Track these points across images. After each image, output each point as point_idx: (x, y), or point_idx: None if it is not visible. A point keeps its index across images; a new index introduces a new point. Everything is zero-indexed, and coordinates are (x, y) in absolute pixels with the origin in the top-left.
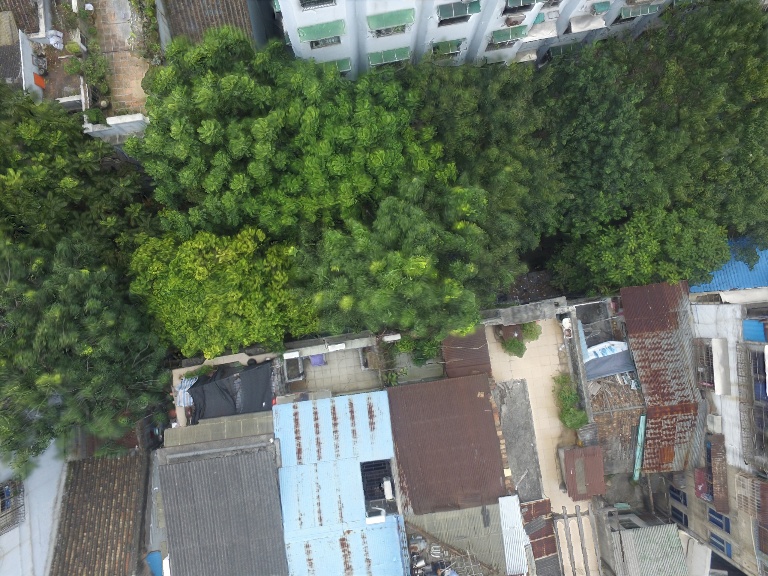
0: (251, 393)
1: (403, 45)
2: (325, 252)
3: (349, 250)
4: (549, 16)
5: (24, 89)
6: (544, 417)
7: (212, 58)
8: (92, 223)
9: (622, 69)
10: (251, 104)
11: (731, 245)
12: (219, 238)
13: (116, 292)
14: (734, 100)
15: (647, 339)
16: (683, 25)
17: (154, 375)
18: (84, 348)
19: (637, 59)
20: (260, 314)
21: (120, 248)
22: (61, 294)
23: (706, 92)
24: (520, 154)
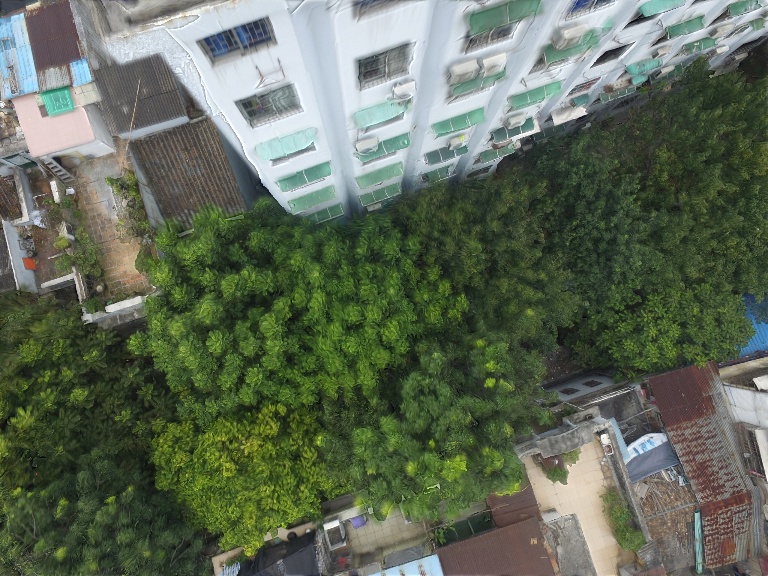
0: None
1: (392, 182)
2: (353, 431)
3: (382, 447)
4: None
5: (16, 280)
6: (598, 537)
7: (208, 256)
8: (106, 418)
9: (613, 162)
10: (254, 293)
11: (749, 305)
12: (240, 422)
13: (141, 481)
14: (730, 175)
15: (686, 430)
16: (666, 108)
17: (194, 572)
18: (121, 573)
19: (625, 144)
20: (295, 500)
21: (138, 436)
22: (91, 533)
23: (702, 175)
24: (529, 277)
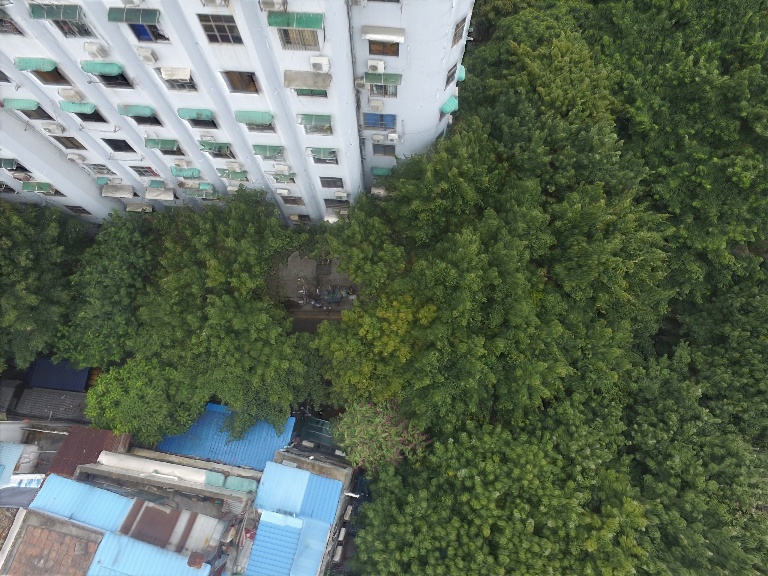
0: None
1: None
2: None
3: None
4: (113, 181)
5: None
6: None
7: None
8: None
9: None
10: None
11: None
12: None
13: None
14: None
15: None
16: (202, 213)
17: None
18: None
19: None
20: None
21: None
22: None
23: None
24: None
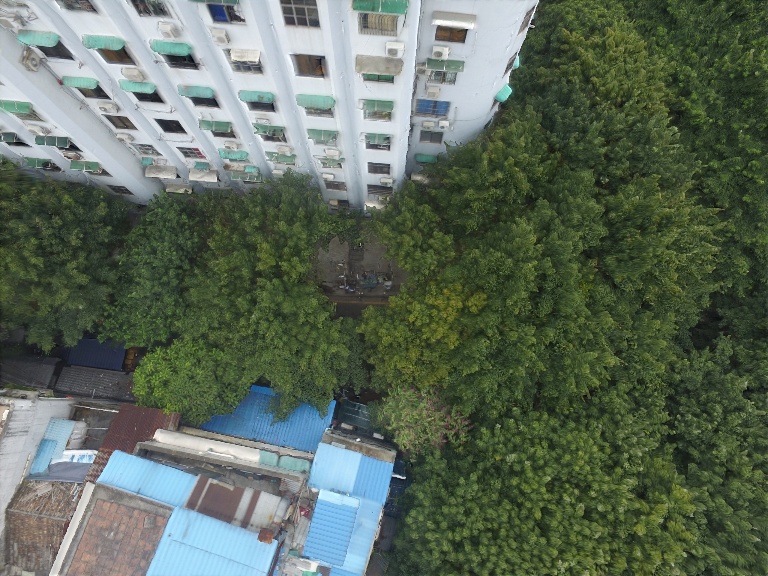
0: None
1: None
2: None
3: None
4: (158, 161)
5: None
6: None
7: None
8: None
9: None
10: None
11: None
12: None
13: None
14: None
15: None
16: (249, 196)
17: None
18: None
19: None
20: None
21: None
22: None
23: None
24: (27, 258)
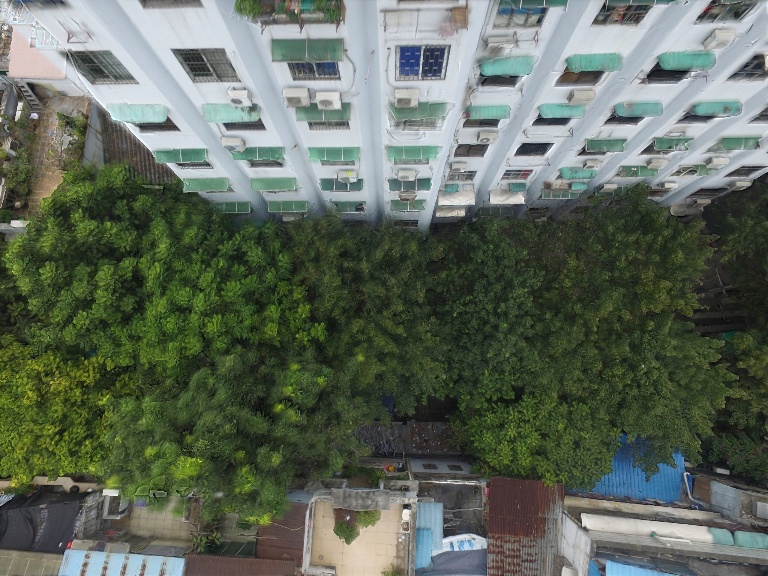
0: (54, 528)
1: (302, 199)
2: None
3: (142, 420)
4: (463, 187)
5: None
6: None
7: (85, 199)
8: None
9: (522, 253)
10: (113, 246)
11: None
12: (66, 361)
13: None
14: (634, 304)
15: (507, 543)
16: (592, 220)
17: None
18: None
19: (546, 242)
20: (75, 451)
21: None
22: None
23: (602, 293)
24: (387, 328)
